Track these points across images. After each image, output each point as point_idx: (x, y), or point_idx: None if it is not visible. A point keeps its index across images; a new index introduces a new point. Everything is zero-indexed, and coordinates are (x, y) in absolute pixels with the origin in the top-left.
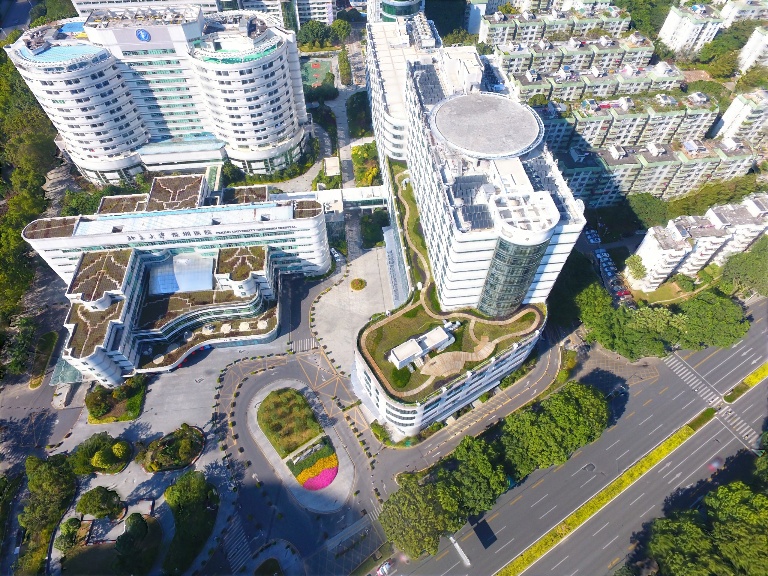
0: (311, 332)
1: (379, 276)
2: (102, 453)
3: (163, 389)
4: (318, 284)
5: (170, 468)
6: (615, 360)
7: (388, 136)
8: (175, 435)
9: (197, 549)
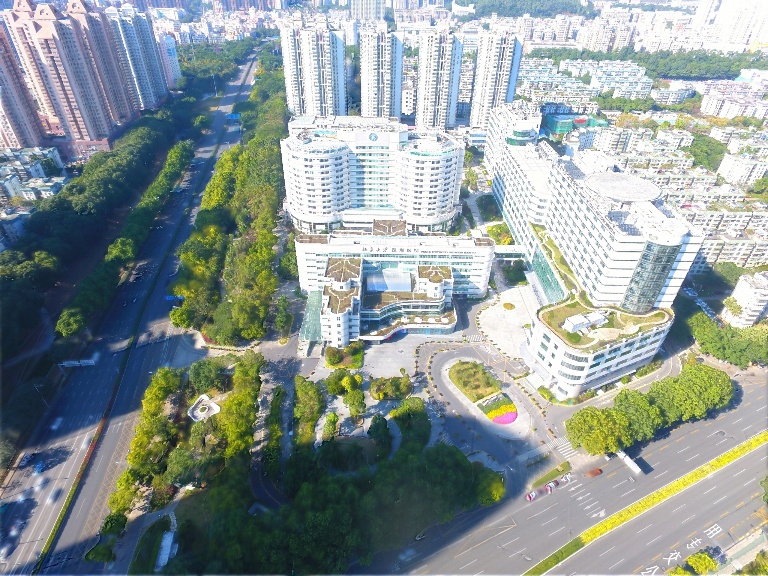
0: (479, 331)
1: (524, 303)
2: None
3: (376, 353)
4: (478, 304)
5: (391, 399)
6: (726, 369)
7: (533, 207)
8: (392, 379)
9: None
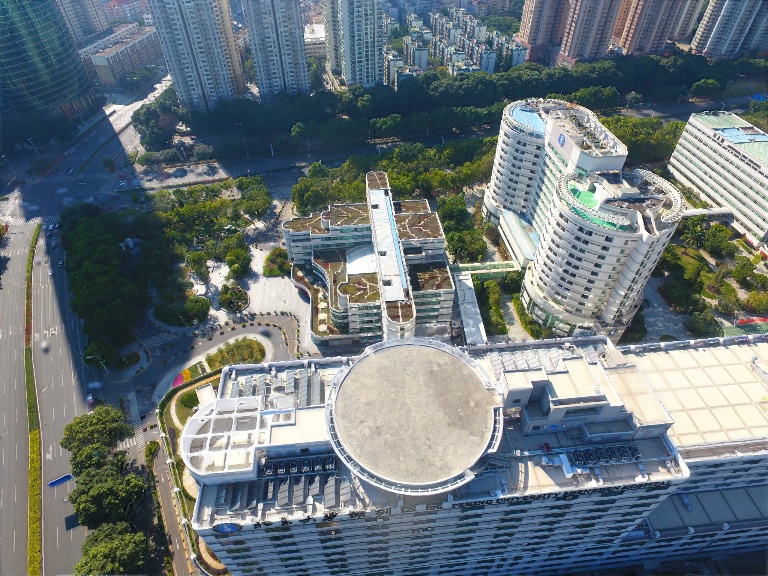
0: None
1: None
2: (232, 259)
3: (283, 284)
4: None
5: None
6: None
7: None
8: None
9: (164, 320)
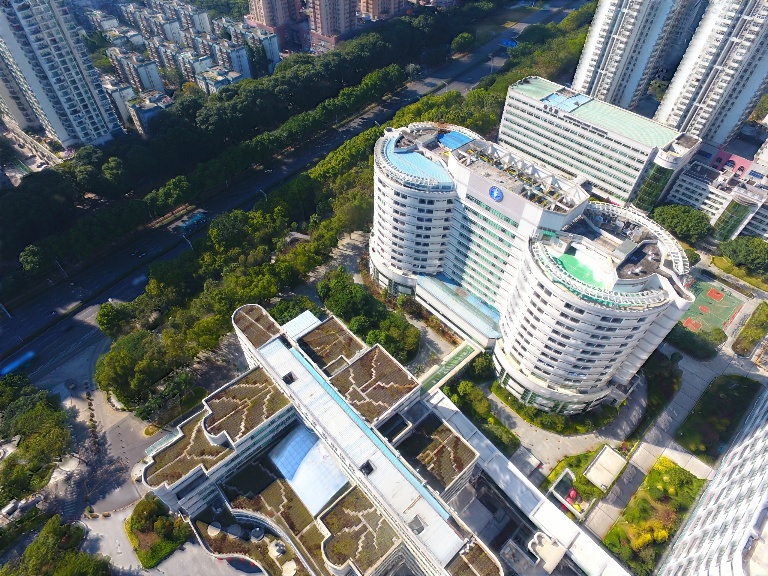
0: None
1: None
2: None
3: (191, 562)
4: None
5: None
6: None
7: None
8: None
9: None
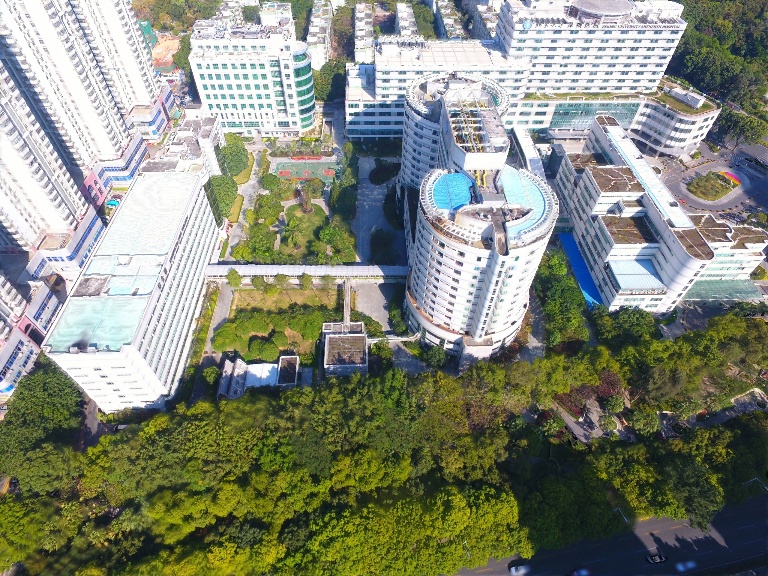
0: None
1: None
2: None
3: None
4: None
5: None
6: None
7: (524, 82)
8: None
9: None
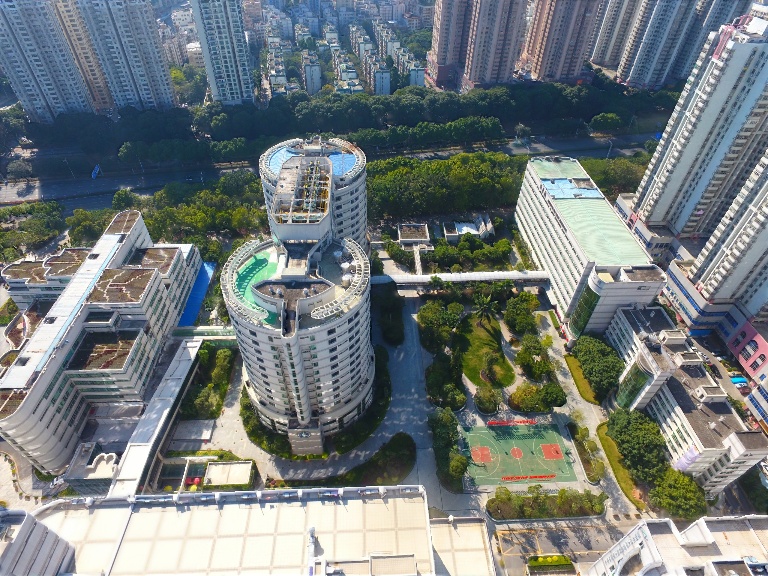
0: None
1: None
2: None
3: None
4: None
5: None
6: None
7: None
8: None
9: None
